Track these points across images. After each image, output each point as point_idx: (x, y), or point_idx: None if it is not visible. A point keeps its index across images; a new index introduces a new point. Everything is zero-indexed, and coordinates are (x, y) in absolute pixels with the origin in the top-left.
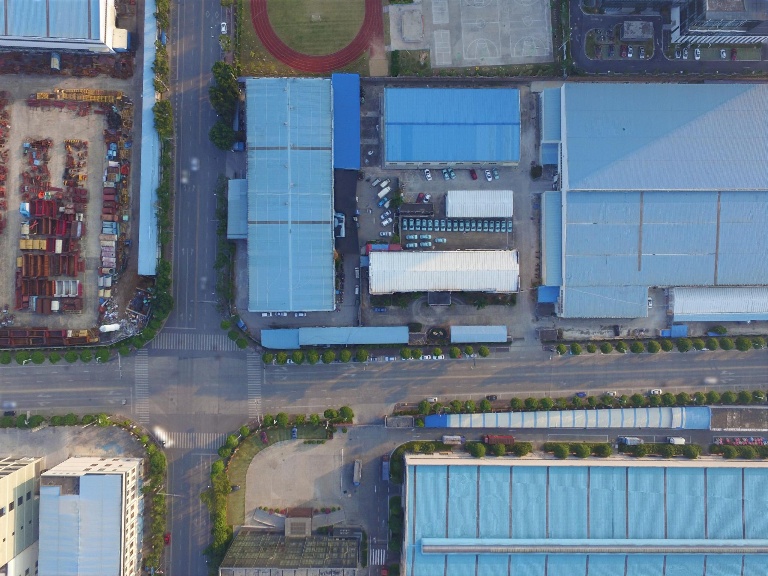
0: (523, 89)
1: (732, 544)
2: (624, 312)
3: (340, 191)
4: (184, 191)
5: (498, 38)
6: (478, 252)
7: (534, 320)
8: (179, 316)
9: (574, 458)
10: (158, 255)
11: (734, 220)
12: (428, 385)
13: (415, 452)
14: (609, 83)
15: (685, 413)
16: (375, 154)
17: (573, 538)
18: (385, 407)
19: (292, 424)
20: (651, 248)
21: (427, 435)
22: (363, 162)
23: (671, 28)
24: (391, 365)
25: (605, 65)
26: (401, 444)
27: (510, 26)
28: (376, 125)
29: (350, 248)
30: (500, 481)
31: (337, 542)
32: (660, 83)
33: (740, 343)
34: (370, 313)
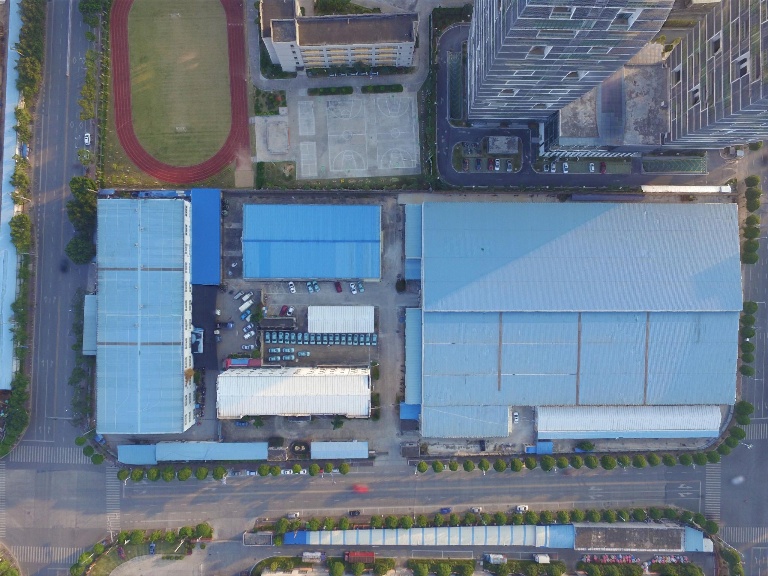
0: (390, 201)
1: None
2: (484, 432)
3: (199, 306)
4: (45, 302)
5: (365, 150)
6: (329, 376)
7: (399, 434)
8: (37, 429)
9: None
10: (16, 368)
11: (595, 340)
12: (290, 499)
13: (273, 570)
14: (469, 202)
15: (549, 532)
16: (239, 266)
17: None
18: (246, 522)
19: (150, 539)
20: (511, 368)
21: (288, 551)
22: (226, 274)
23: (539, 141)
24: (253, 479)
25: (472, 178)
26: (261, 560)
27: (377, 138)
28: (240, 237)
29: (209, 363)
30: None
31: None
32: (521, 202)
33: (604, 462)
34: (232, 426)
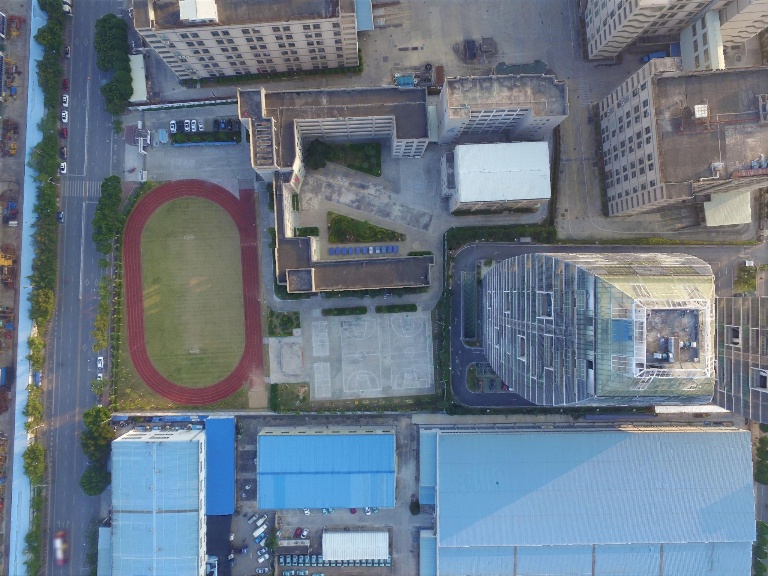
0: (404, 421)
1: None
2: None
3: (213, 535)
4: (58, 527)
5: (379, 370)
6: None
7: None
8: None
9: None
10: None
11: (609, 571)
12: None
13: None
14: (484, 434)
15: None
16: (253, 488)
17: None
18: None
19: None
20: None
21: None
22: (240, 497)
23: None
24: None
25: (486, 398)
26: None
27: (391, 358)
28: (254, 459)
29: None
30: None
31: None
32: (535, 433)
33: None
34: None
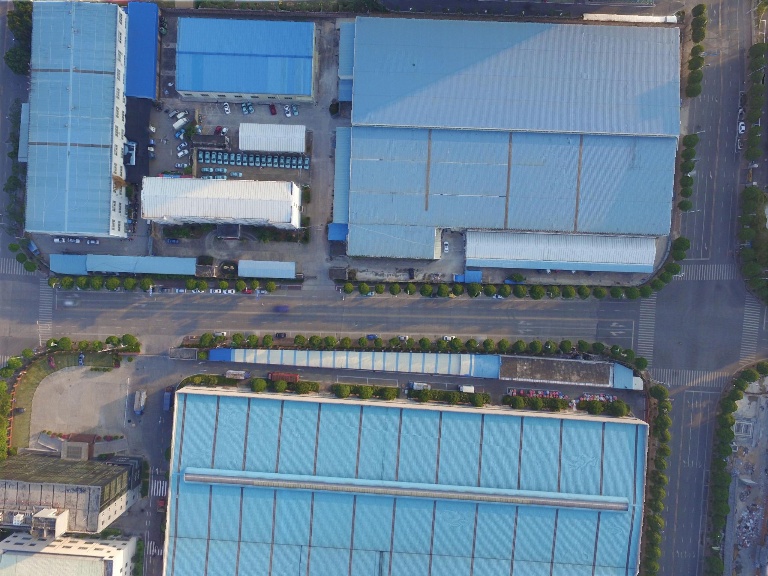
0: (328, 26)
1: (503, 493)
2: (410, 252)
3: (133, 119)
4: None
5: None
6: (252, 181)
7: (328, 259)
8: None
9: (354, 399)
10: None
11: (526, 162)
12: (218, 319)
13: (196, 384)
14: (402, 18)
15: (474, 360)
16: None
17: (340, 477)
18: (174, 339)
19: (79, 350)
20: (439, 188)
21: (214, 369)
22: (163, 93)
23: None
24: (182, 297)
25: (411, 3)
26: (187, 377)
27: None
28: None
29: (141, 177)
30: (270, 415)
31: (106, 466)
32: (455, 20)
33: (532, 291)
34: (163, 244)
